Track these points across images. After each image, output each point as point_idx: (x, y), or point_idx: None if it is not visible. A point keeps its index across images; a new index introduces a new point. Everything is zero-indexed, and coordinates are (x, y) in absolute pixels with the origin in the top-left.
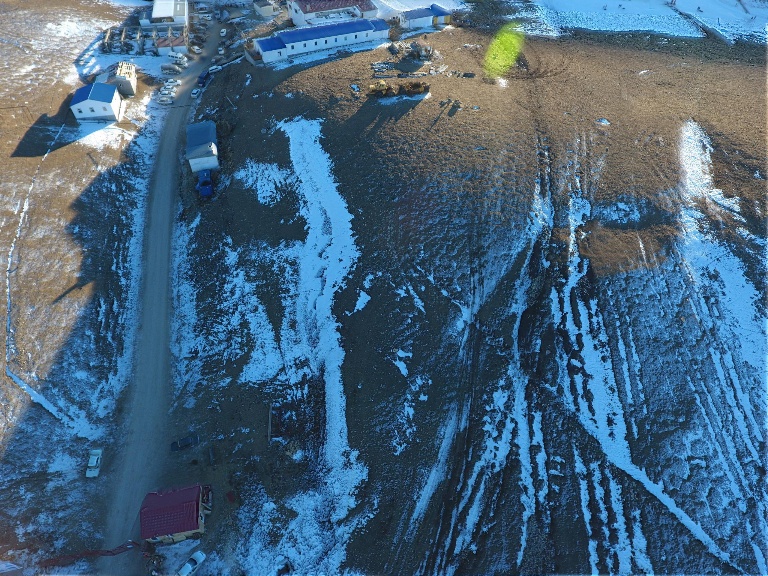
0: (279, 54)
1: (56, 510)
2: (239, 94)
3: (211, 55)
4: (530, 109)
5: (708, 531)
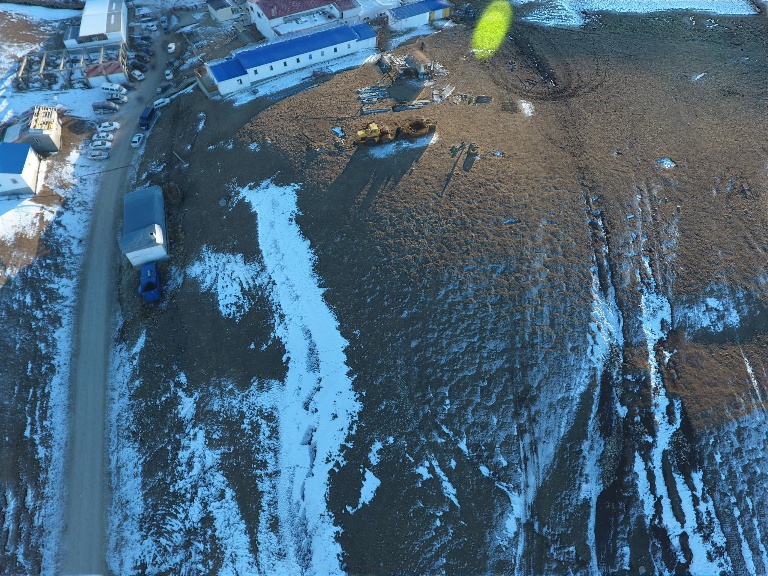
0: (239, 82)
1: None
2: (191, 143)
3: (157, 81)
4: (569, 150)
5: None
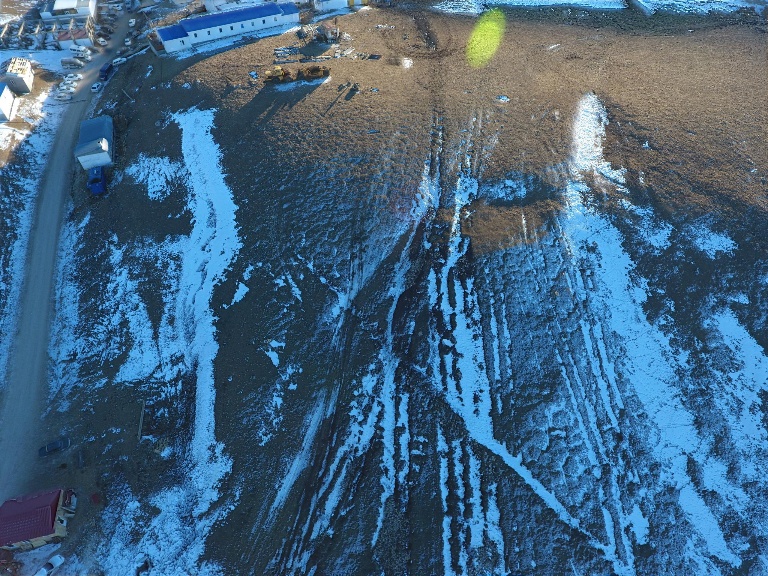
0: (182, 43)
1: None
2: (139, 86)
3: (118, 47)
4: (430, 89)
5: (561, 499)
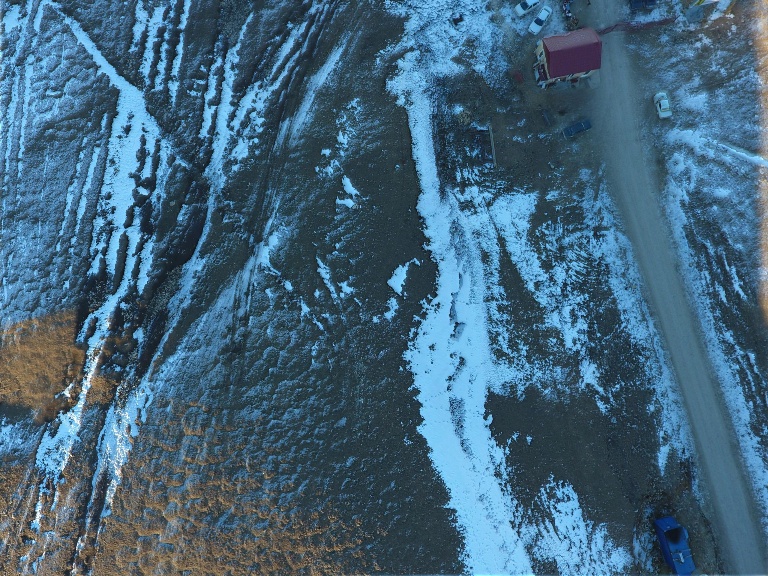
0: None
1: (679, 62)
2: None
3: None
4: None
5: (73, 38)
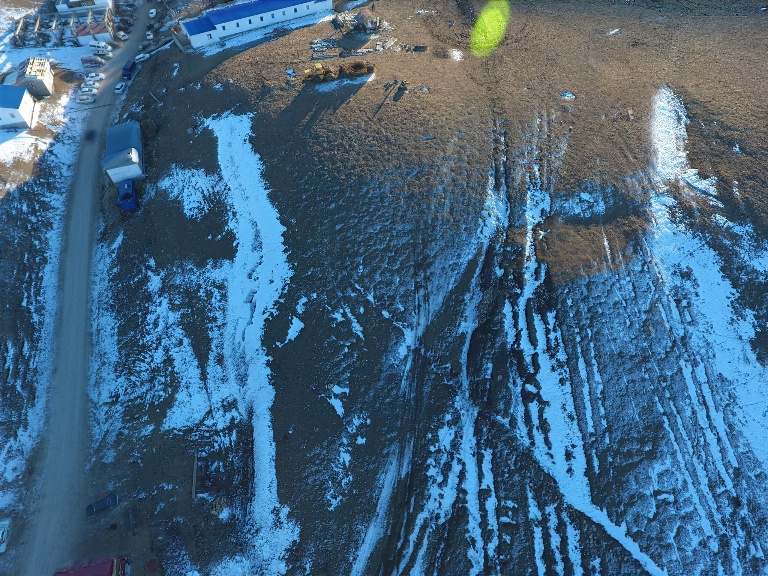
0: (209, 37)
1: None
2: (166, 87)
3: (139, 41)
4: (486, 86)
5: None
